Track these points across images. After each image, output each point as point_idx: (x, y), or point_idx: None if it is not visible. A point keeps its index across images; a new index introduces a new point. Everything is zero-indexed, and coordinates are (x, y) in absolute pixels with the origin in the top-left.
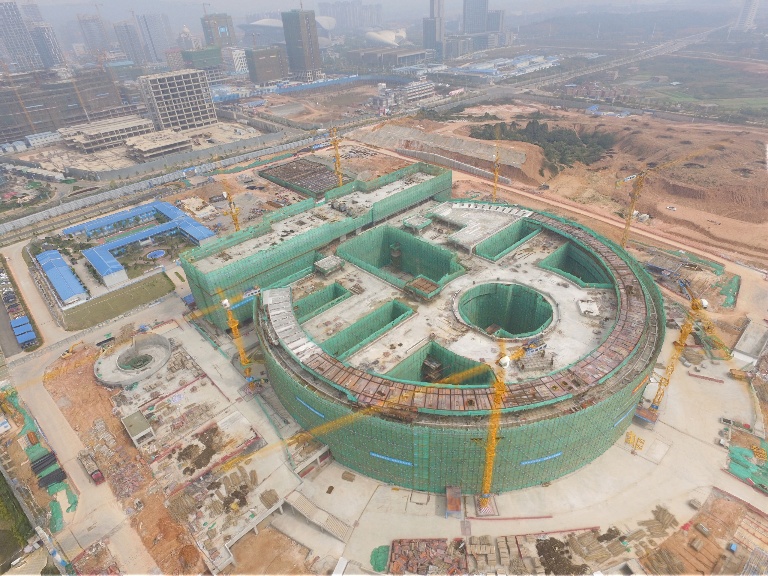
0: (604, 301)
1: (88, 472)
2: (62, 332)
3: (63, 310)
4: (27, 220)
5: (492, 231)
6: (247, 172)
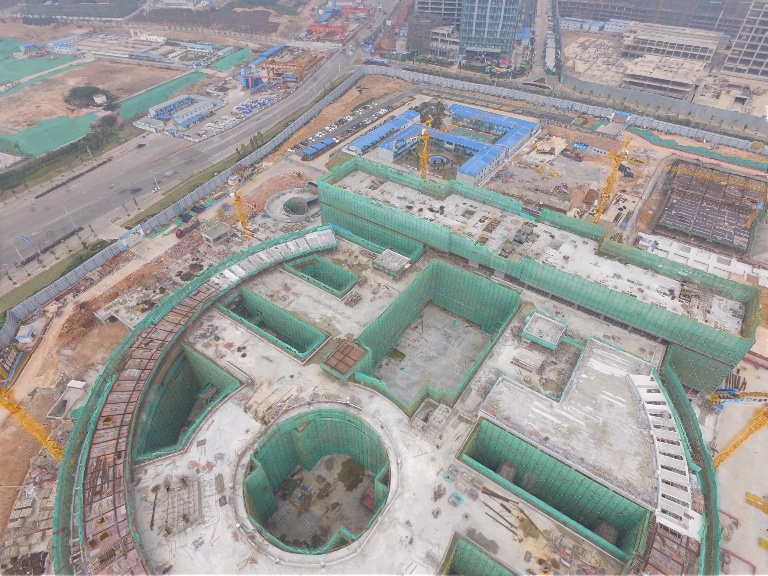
0: None
1: (179, 227)
2: (324, 163)
3: (342, 151)
4: (463, 85)
5: (556, 446)
6: (665, 151)
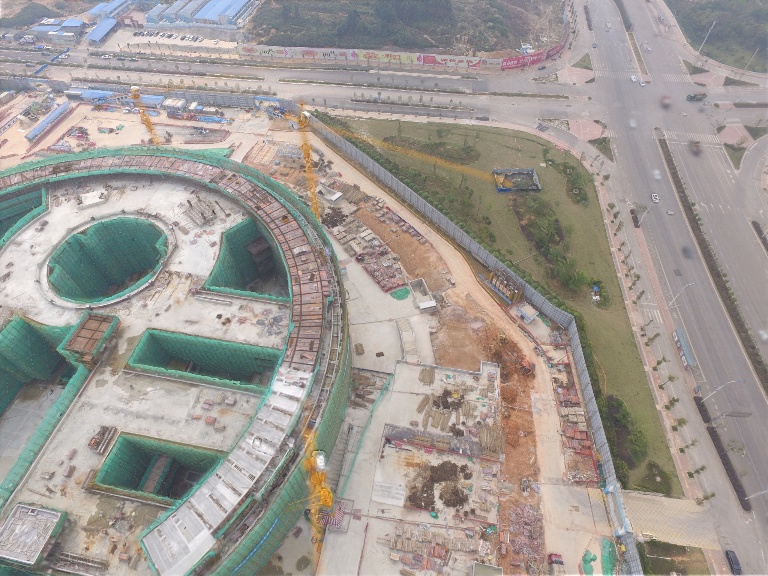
0: (73, 193)
1: None
2: None
3: None
4: None
5: None
6: None
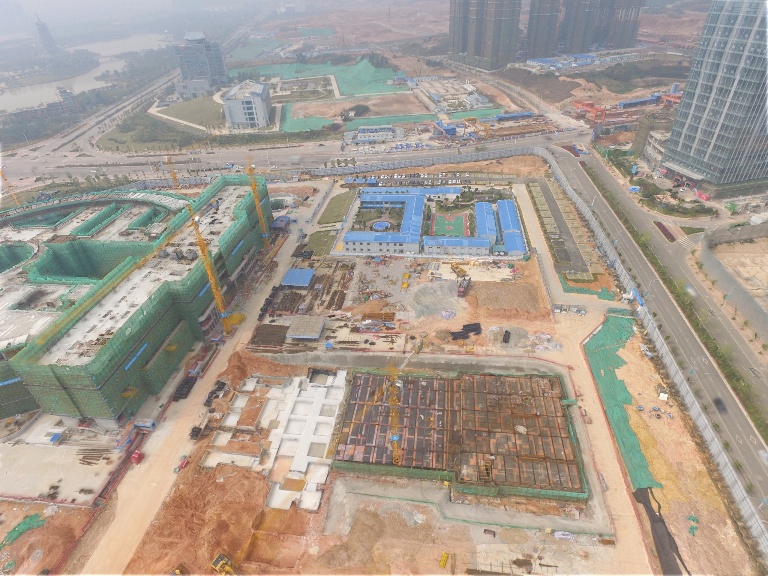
0: None
1: None
2: (343, 192)
3: None
4: None
5: None
6: (569, 358)
